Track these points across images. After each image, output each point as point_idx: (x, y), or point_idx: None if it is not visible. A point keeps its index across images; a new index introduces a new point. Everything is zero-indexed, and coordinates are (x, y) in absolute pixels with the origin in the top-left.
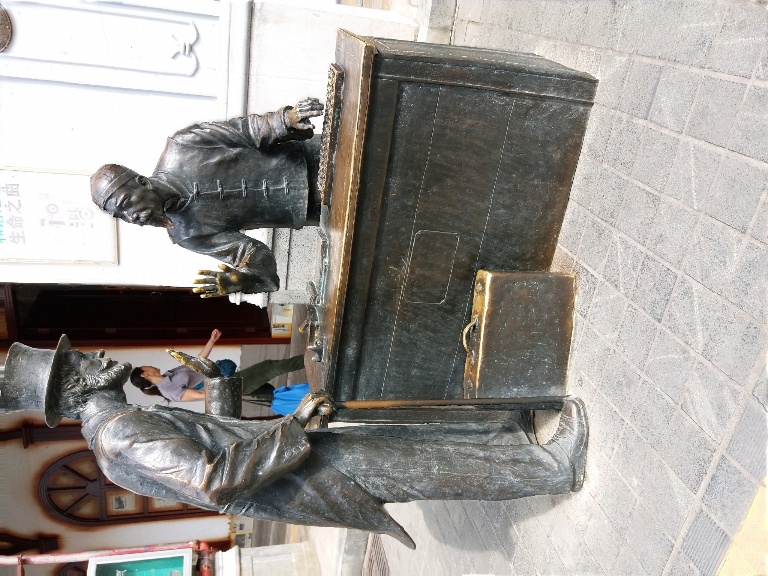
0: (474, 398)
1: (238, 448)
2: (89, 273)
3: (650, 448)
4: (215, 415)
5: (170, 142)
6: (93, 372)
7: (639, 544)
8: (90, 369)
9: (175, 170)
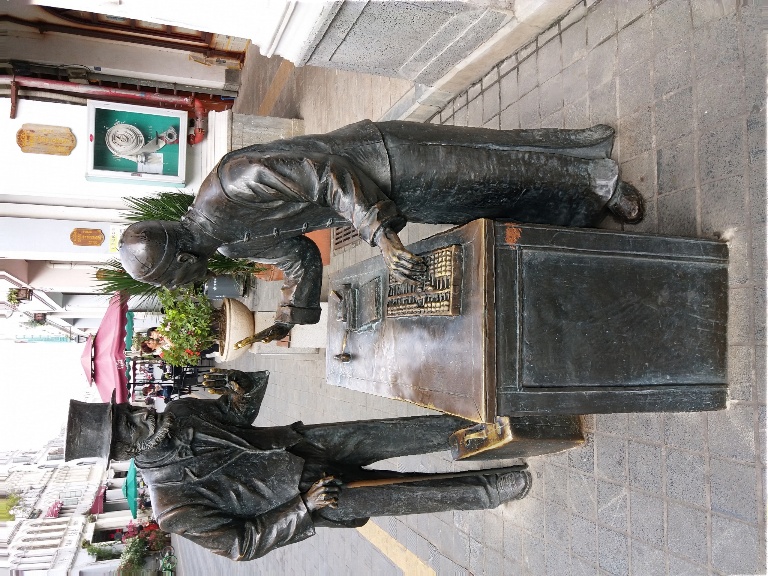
0: (452, 473)
1: (262, 537)
2: (80, 3)
3: (545, 571)
4: (244, 448)
5: (220, 193)
6: (143, 440)
7: (508, 572)
8: (140, 439)
9: (224, 222)
